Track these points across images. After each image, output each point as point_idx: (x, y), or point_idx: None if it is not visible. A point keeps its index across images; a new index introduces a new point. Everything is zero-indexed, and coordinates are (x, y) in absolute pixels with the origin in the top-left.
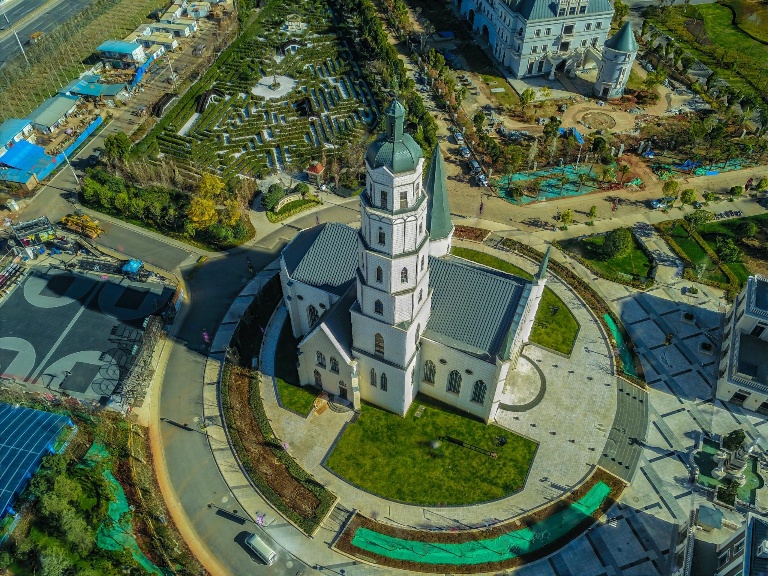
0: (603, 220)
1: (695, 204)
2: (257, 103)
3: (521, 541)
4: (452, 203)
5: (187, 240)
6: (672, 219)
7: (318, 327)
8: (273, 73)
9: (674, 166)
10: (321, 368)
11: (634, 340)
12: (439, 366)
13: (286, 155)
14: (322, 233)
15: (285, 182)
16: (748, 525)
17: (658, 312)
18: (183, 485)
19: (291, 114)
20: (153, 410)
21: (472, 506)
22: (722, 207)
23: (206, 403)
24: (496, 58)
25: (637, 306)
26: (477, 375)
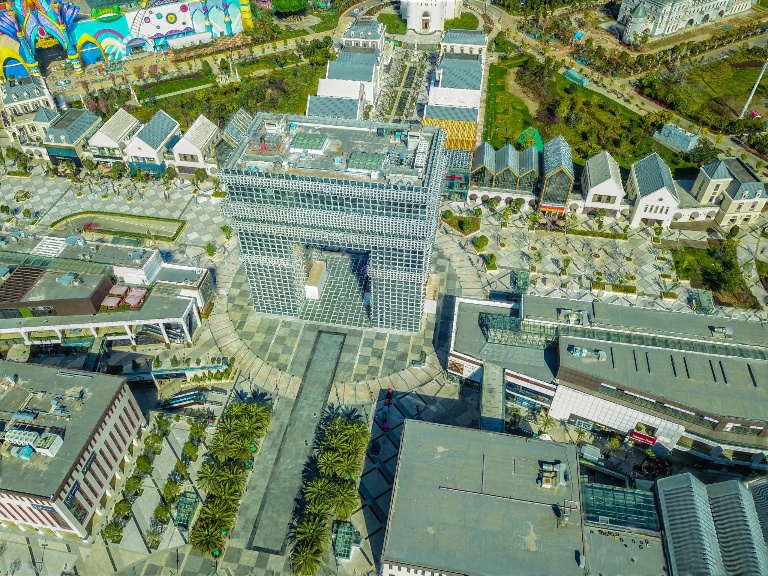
0: None
1: None
2: None
3: None
4: None
5: None
6: (535, 55)
7: None
8: None
9: (577, 56)
10: None
11: None
12: None
13: None
14: None
15: None
16: None
17: None
18: (367, 3)
19: None
20: None
21: None
22: None
23: None
24: None
25: None
26: None
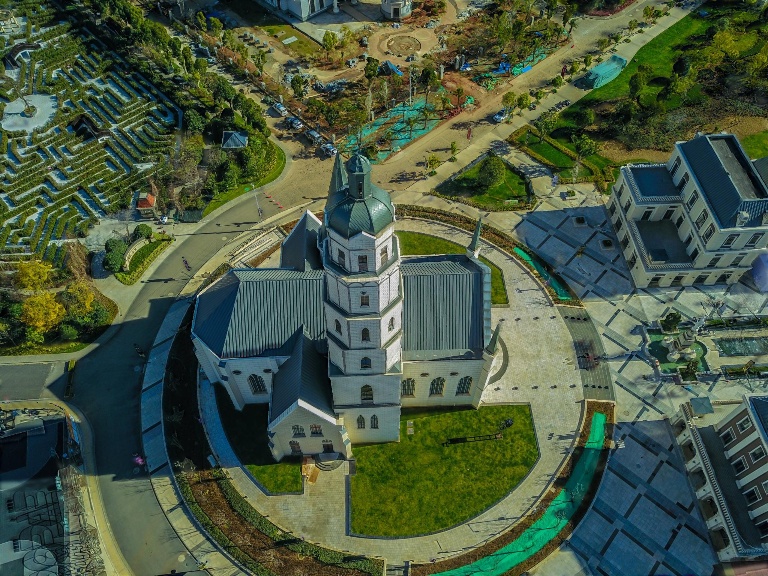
0: (462, 151)
1: (529, 106)
2: (20, 141)
3: (564, 505)
4: (313, 186)
5: (35, 350)
6: (518, 128)
7: (295, 407)
8: (21, 97)
9: (493, 72)
10: (300, 438)
11: (549, 262)
12: (420, 380)
13: (97, 195)
14: (238, 296)
15: (115, 229)
16: (750, 406)
17: (554, 226)
18: None
19: (72, 141)
20: (124, 575)
21: (507, 496)
22: (551, 101)
23: (182, 534)
24: (269, 3)
25: (534, 227)
26: (463, 373)
